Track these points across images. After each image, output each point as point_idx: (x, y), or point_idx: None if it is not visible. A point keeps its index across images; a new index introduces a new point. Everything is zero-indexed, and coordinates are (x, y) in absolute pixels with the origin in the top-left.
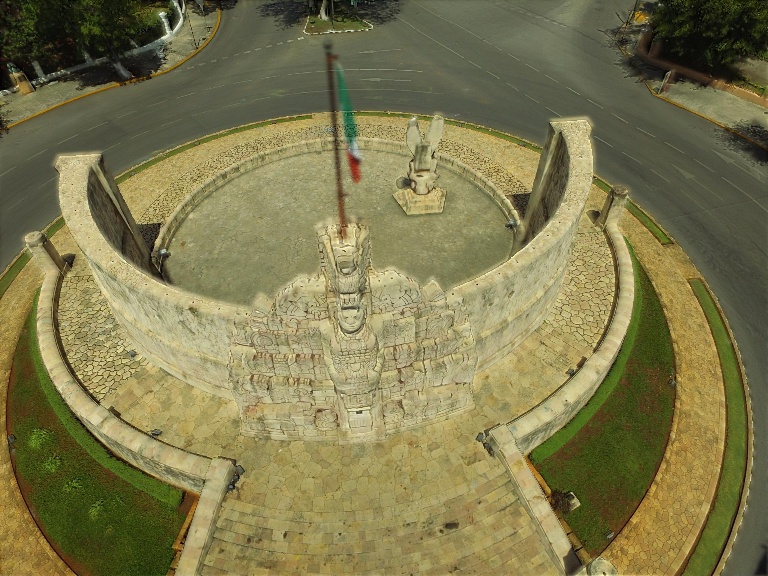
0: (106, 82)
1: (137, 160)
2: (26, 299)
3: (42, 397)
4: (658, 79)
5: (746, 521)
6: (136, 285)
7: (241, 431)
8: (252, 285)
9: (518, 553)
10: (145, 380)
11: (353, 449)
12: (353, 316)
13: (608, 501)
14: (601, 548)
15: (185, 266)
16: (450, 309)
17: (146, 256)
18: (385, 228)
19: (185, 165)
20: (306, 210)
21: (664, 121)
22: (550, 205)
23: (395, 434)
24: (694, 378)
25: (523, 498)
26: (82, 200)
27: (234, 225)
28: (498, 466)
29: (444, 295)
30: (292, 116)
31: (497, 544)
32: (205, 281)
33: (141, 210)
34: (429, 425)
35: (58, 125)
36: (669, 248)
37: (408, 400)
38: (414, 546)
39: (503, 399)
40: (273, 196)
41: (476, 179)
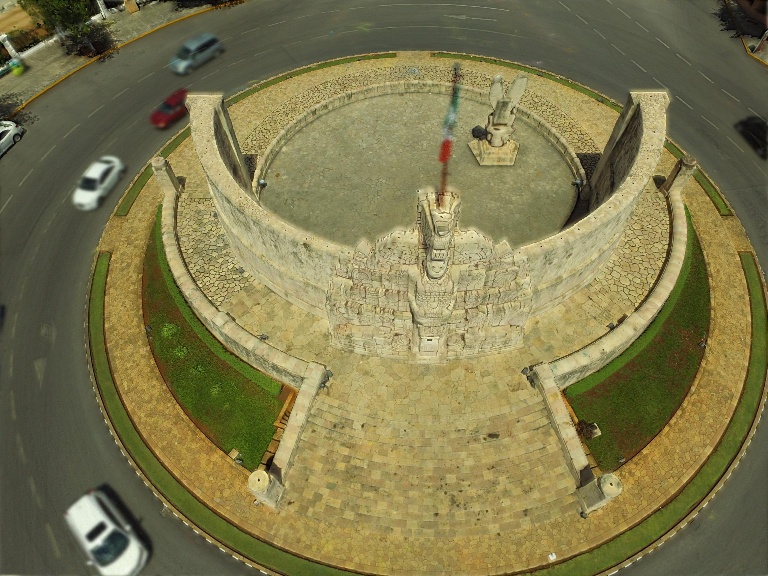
0: (203, 4)
1: (234, 89)
2: (149, 214)
3: (169, 298)
4: (757, 35)
5: (742, 465)
6: (260, 220)
7: (331, 344)
8: (337, 219)
9: (544, 463)
10: (253, 294)
11: (419, 368)
12: (440, 266)
13: (625, 434)
14: (613, 469)
15: (279, 197)
16: (516, 265)
17: (248, 186)
18: (458, 176)
19: (278, 98)
20: (387, 152)
21: (753, 84)
22: (617, 172)
23: (455, 360)
24: (724, 343)
25: (554, 422)
26: (211, 139)
27: (322, 161)
28: (537, 395)
29: (513, 254)
30: (377, 53)
31: (528, 454)
32: (297, 212)
33: (240, 140)
34: (483, 356)
35: (162, 48)
36: (728, 220)
37: (470, 335)
38: (462, 447)
39: (548, 342)
40: (357, 136)
41: (550, 134)
